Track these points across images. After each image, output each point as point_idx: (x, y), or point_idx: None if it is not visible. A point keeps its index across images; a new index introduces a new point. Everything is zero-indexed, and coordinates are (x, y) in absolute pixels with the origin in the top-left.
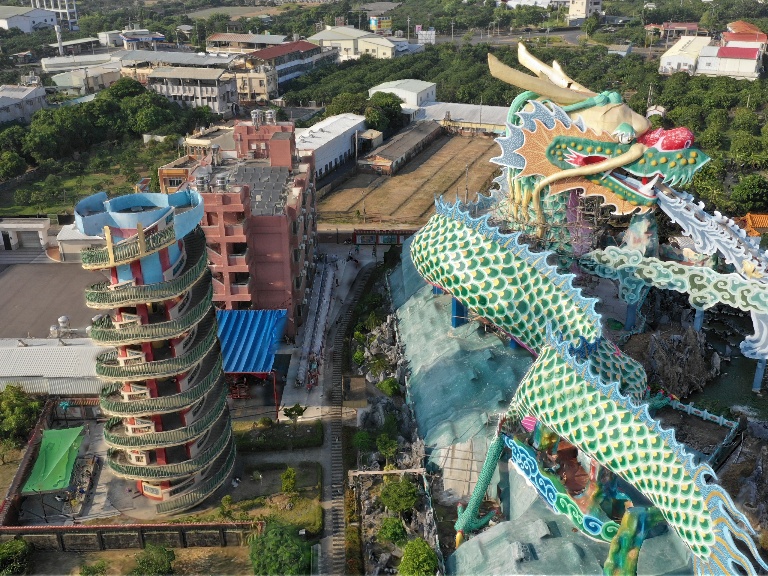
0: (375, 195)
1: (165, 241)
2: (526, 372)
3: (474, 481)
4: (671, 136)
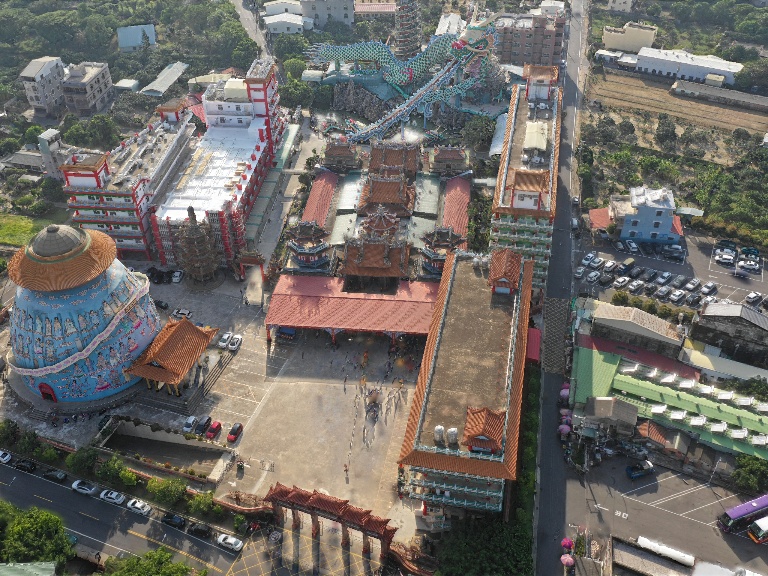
0: (632, 87)
1: None
2: None
3: None
4: None
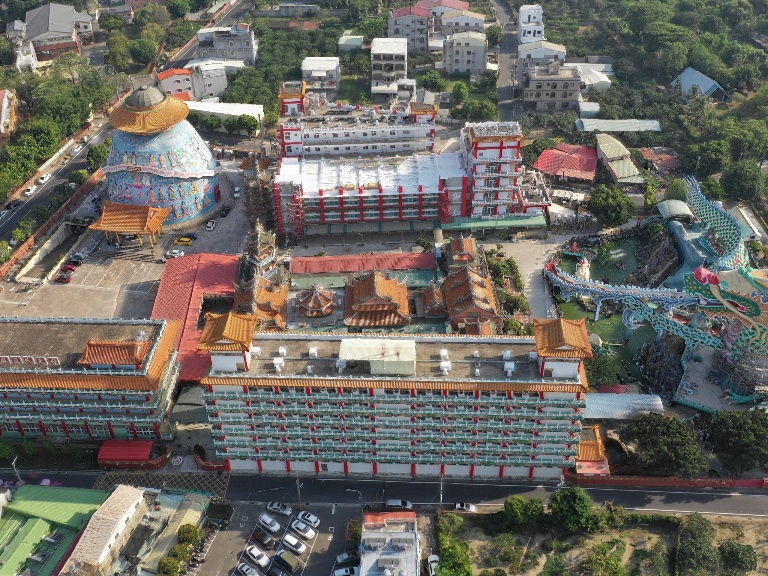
0: None
1: None
2: None
3: None
4: None
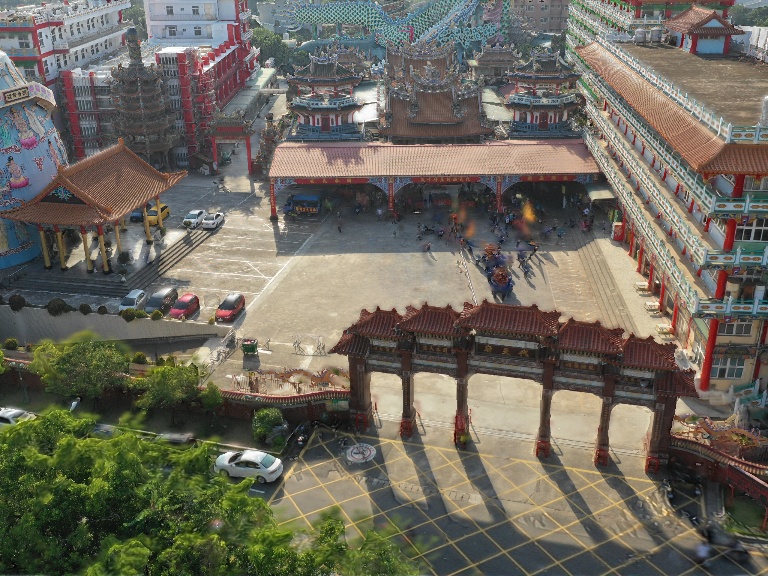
0: None
1: None
2: None
3: None
4: None
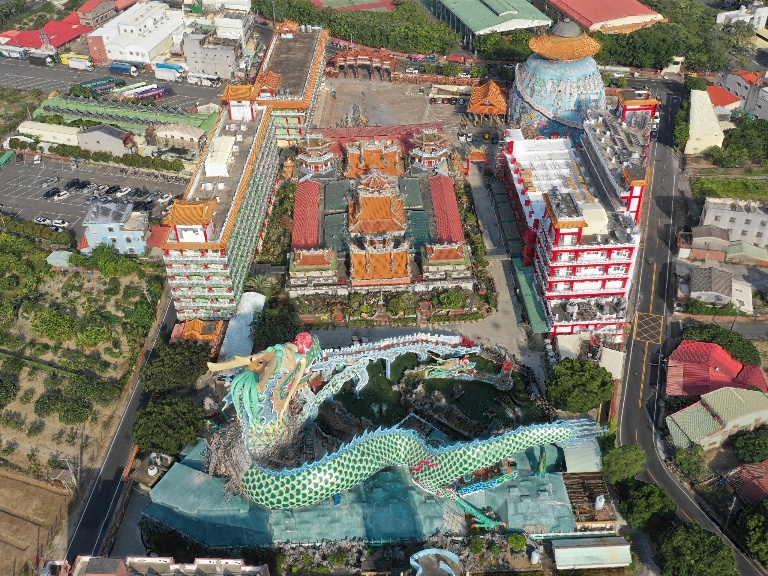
0: None
1: (462, 569)
2: (392, 477)
3: (457, 518)
4: (308, 341)
